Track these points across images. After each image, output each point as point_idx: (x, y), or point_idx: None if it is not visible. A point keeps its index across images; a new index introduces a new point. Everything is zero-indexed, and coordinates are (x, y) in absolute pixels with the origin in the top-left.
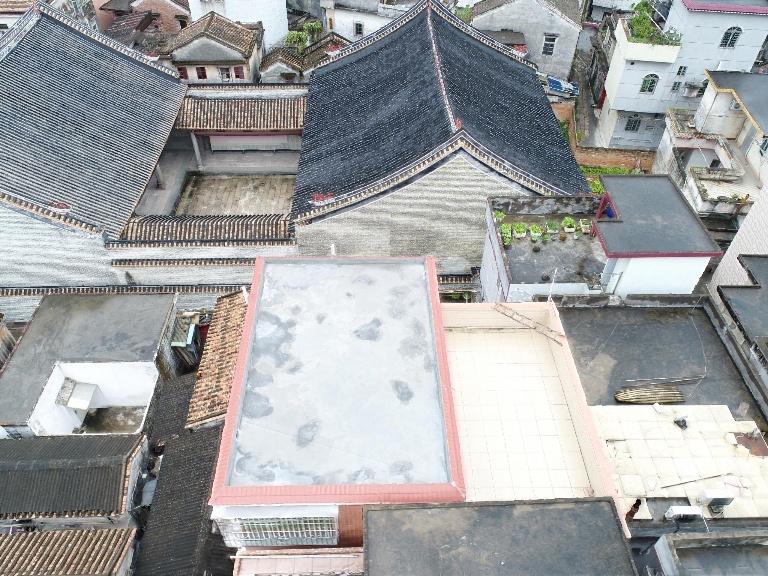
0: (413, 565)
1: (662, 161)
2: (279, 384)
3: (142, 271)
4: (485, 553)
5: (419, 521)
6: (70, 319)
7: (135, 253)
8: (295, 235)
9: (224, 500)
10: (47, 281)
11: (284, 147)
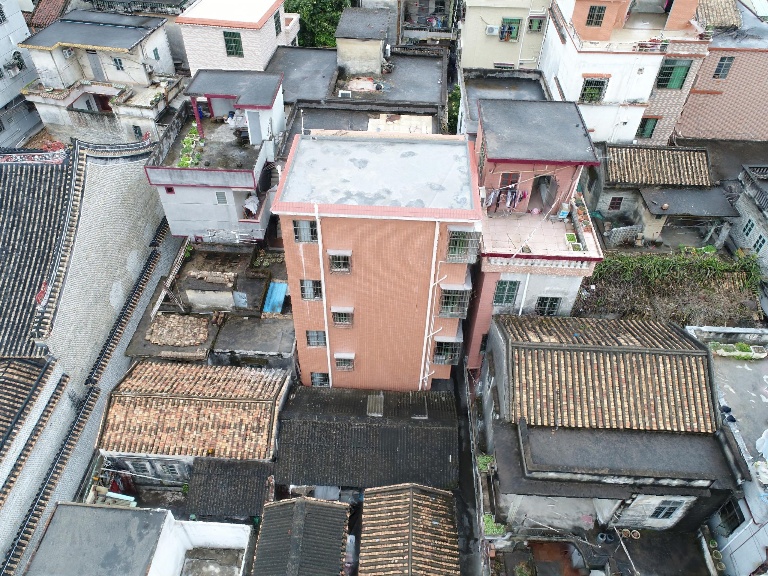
0: (513, 148)
1: (63, 126)
2: (399, 197)
3: None
4: (505, 130)
5: (493, 145)
6: None
7: None
8: (50, 353)
9: (480, 212)
10: None
11: None
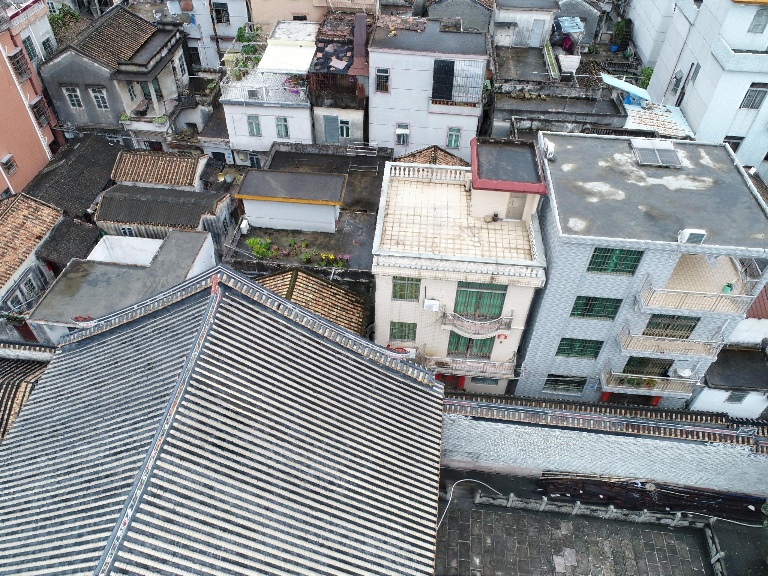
0: None
1: None
2: None
3: None
4: None
5: None
6: None
7: None
8: None
9: None
10: None
11: None
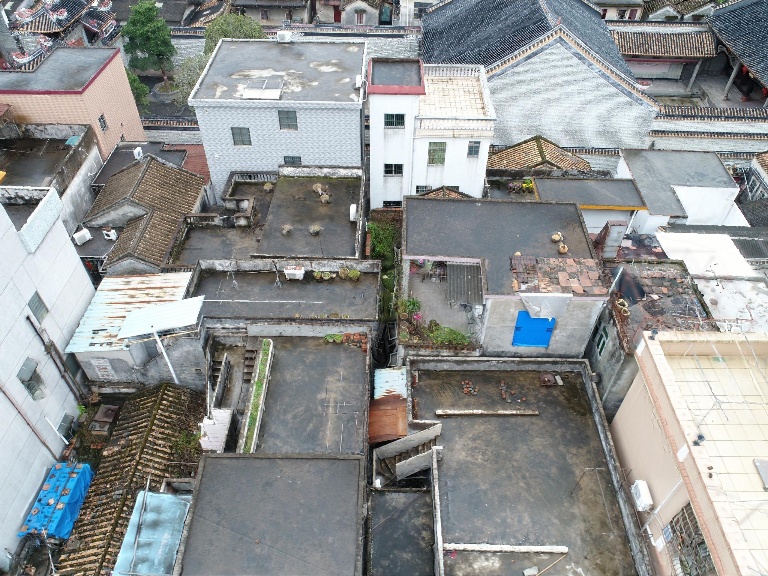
0: None
1: None
2: None
3: (665, 141)
4: None
5: None
6: (654, 163)
7: (671, 125)
8: None
9: None
10: (589, 147)
11: (663, 76)
